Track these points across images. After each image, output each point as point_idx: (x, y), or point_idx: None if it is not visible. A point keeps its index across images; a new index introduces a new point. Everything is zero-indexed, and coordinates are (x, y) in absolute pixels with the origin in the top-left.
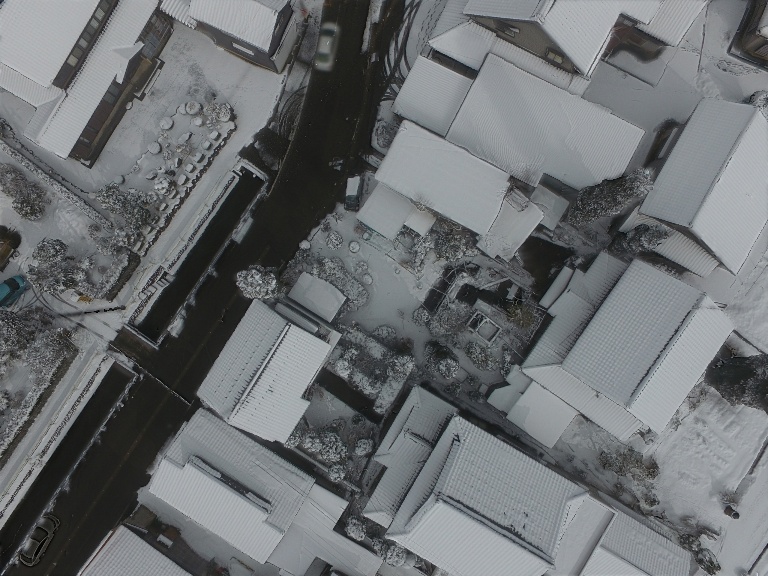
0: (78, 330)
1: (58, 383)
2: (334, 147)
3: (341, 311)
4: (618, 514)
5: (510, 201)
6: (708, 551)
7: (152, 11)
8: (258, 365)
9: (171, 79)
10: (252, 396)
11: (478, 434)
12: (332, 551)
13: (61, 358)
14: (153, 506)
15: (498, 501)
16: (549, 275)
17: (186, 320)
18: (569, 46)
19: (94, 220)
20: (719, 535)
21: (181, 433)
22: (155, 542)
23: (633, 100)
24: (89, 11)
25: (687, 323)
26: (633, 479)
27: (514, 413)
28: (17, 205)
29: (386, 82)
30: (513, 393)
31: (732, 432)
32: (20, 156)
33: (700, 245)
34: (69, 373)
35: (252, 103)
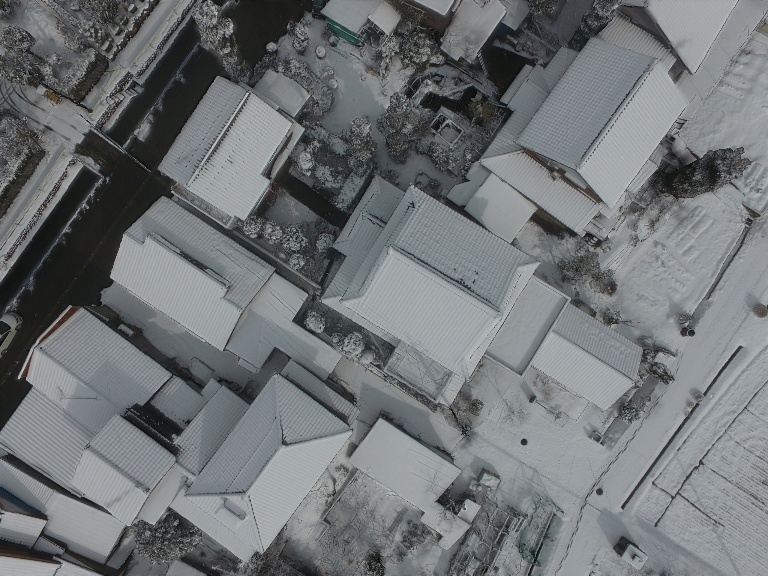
0: (45, 132)
1: (24, 184)
2: None
3: None
4: (572, 308)
5: None
6: (663, 364)
7: None
8: (218, 133)
9: None
10: (211, 164)
11: (433, 203)
12: (291, 342)
13: (26, 146)
14: (116, 306)
15: (449, 258)
16: None
17: (153, 125)
18: None
19: (63, 22)
20: (675, 356)
21: (142, 215)
22: (115, 329)
23: None
24: None
25: (638, 85)
26: (590, 287)
27: (472, 204)
28: None
29: None
30: (472, 187)
31: (690, 256)
32: None
33: (658, 38)
34: (35, 175)
35: None
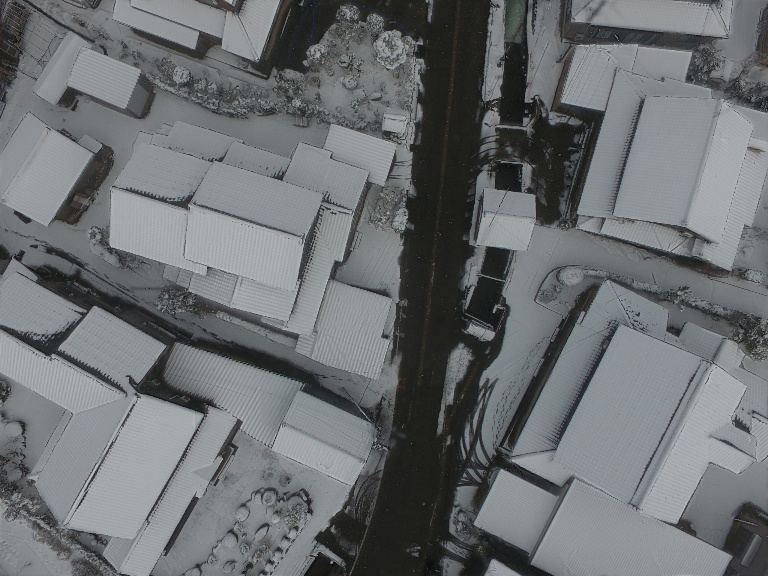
0: None
1: None
2: (412, 533)
3: None
4: None
5: None
6: None
7: (231, 428)
8: None
9: (245, 463)
10: None
11: None
12: None
13: None
14: None
15: None
16: None
17: None
18: (663, 512)
19: None
20: None
21: None
22: None
23: (711, 484)
24: (174, 462)
25: None
26: None
27: None
28: None
29: (462, 466)
30: None
31: None
32: (98, 561)
33: None
34: None
35: (327, 487)
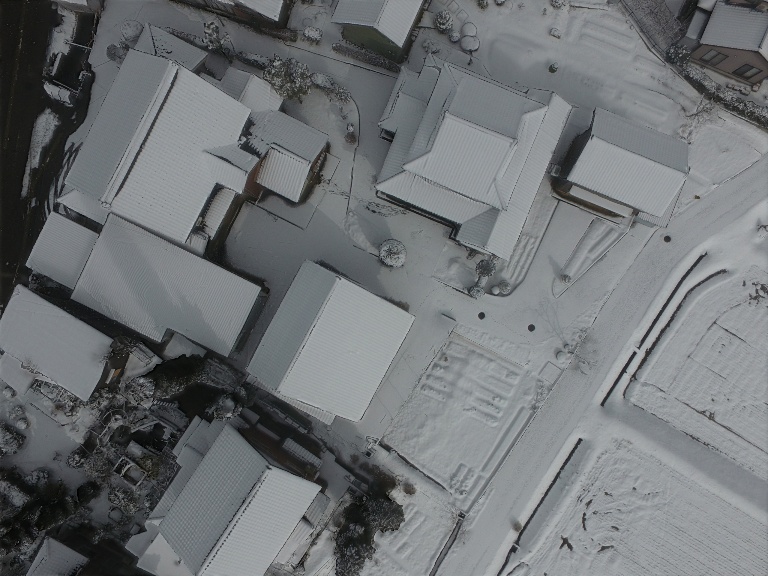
0: None
1: None
2: None
3: None
4: None
5: (137, 355)
6: None
7: None
8: None
9: None
10: None
11: None
12: None
13: None
14: None
15: None
16: None
17: None
18: (153, 221)
19: None
20: None
21: None
22: None
23: (284, 243)
24: None
25: (250, 495)
26: None
27: (144, 561)
28: None
29: None
30: (147, 540)
31: (404, 553)
32: None
33: None
34: None
35: None
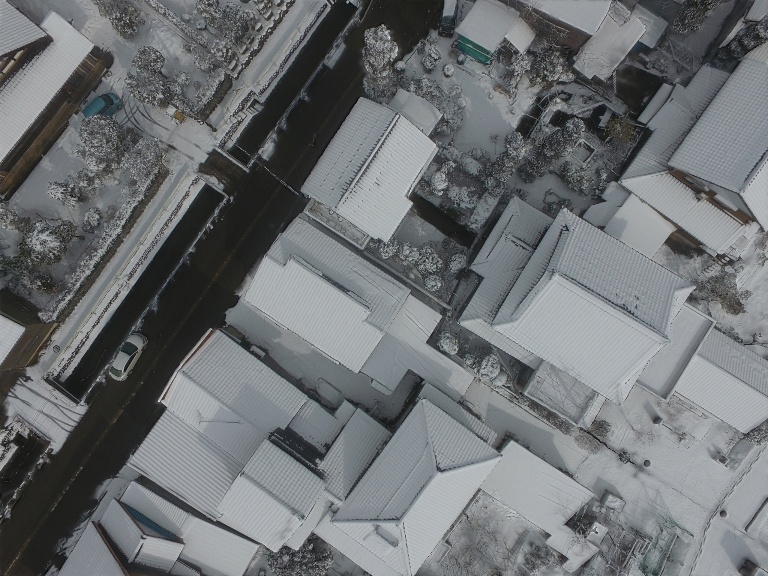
0: (169, 152)
1: (148, 204)
2: None
3: (437, 127)
4: (712, 330)
5: (612, 14)
6: None
7: None
8: (366, 156)
9: None
10: (360, 186)
11: (586, 226)
12: (425, 364)
13: (158, 167)
14: (241, 326)
15: (610, 283)
16: (642, 103)
17: (277, 144)
18: None
19: (187, 41)
20: None
21: (280, 237)
22: (249, 351)
23: None
24: None
25: None
26: (722, 307)
27: (612, 225)
28: (116, 14)
29: None
30: (610, 208)
31: None
32: None
33: None
34: (159, 194)
35: None
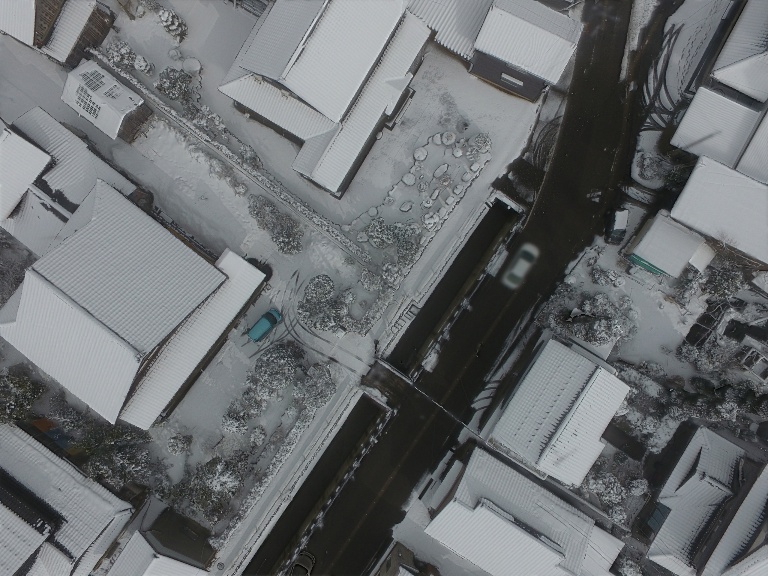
0: (330, 364)
1: None
2: (592, 178)
3: (614, 348)
4: None
5: None
6: None
7: (424, 41)
8: (566, 409)
9: (422, 108)
10: (559, 440)
11: None
12: None
13: None
14: (410, 543)
15: None
16: None
17: (440, 355)
18: None
19: (348, 253)
20: None
21: (464, 474)
22: None
23: None
24: (381, 44)
25: None
26: None
27: None
28: (284, 240)
29: (645, 112)
30: None
31: None
32: (279, 189)
33: None
34: (321, 408)
35: (506, 133)
